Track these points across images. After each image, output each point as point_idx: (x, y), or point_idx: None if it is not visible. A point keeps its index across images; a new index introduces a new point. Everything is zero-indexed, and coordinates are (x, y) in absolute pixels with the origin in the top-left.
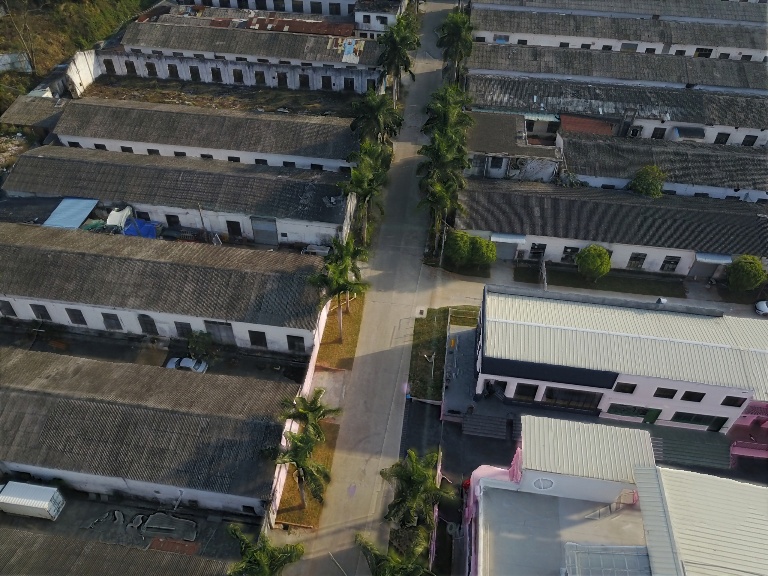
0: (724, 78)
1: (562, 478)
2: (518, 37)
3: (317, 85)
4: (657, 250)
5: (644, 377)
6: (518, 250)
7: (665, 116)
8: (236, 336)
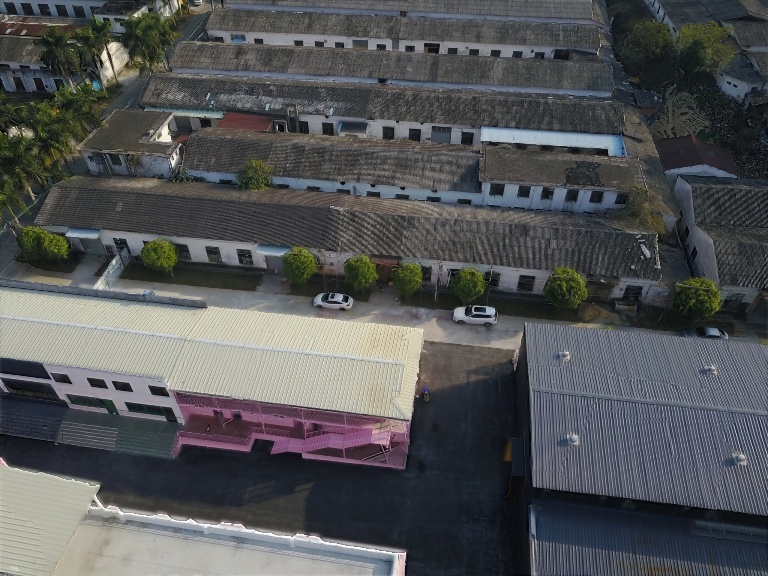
0: (415, 72)
1: None
2: (253, 36)
3: (31, 87)
4: (224, 243)
5: (64, 367)
6: (104, 245)
7: (328, 111)
8: None
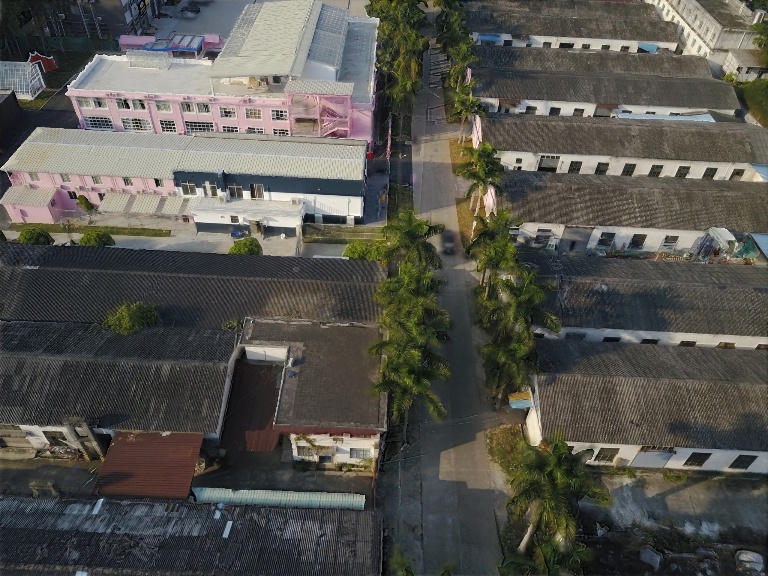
0: None
1: None
2: None
3: None
4: None
5: (264, 134)
6: None
7: None
8: None
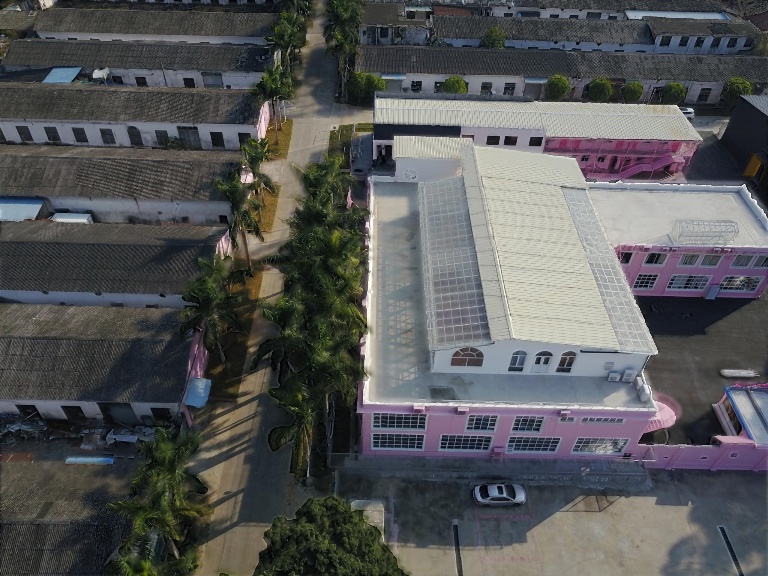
0: None
1: (419, 161)
2: None
3: None
4: (498, 79)
5: (477, 127)
6: (402, 88)
7: (510, 3)
8: (201, 139)
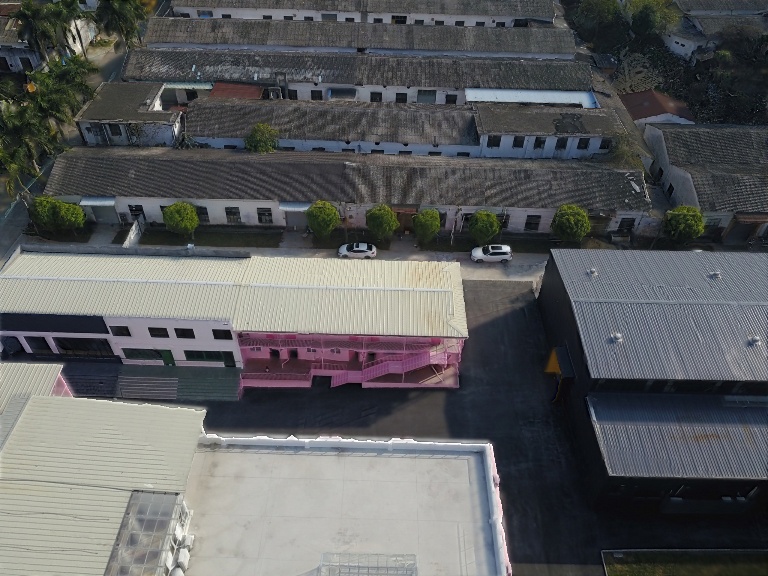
0: (392, 41)
1: None
2: (221, 12)
3: None
4: (245, 203)
5: (126, 318)
6: (118, 213)
7: (317, 78)
8: None
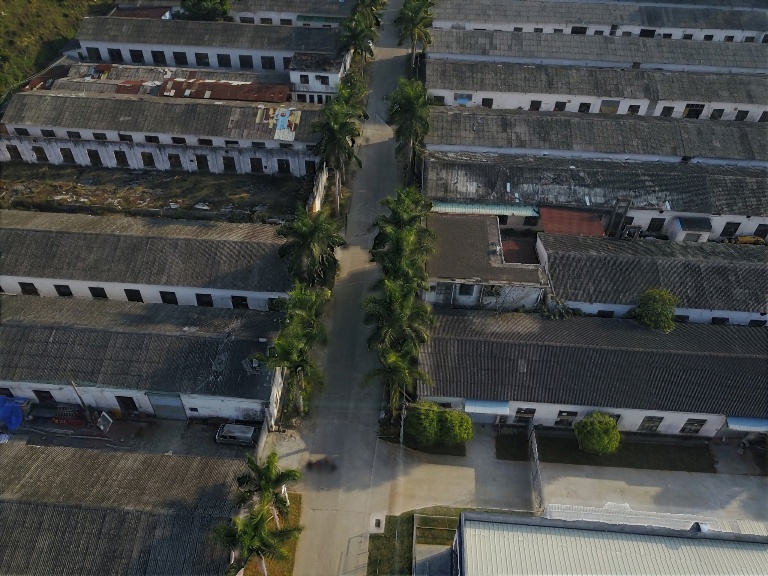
0: (725, 148)
1: None
2: (482, 95)
3: (245, 168)
4: (677, 413)
5: None
6: (500, 415)
7: (664, 205)
8: None
